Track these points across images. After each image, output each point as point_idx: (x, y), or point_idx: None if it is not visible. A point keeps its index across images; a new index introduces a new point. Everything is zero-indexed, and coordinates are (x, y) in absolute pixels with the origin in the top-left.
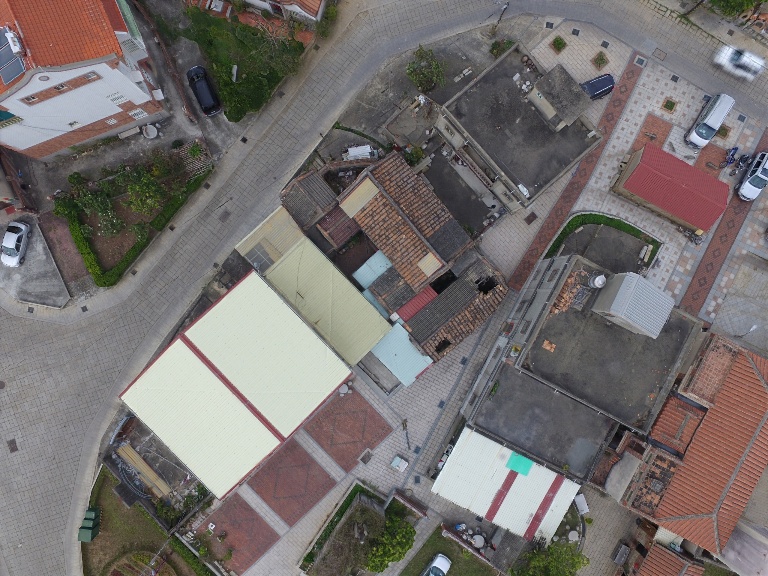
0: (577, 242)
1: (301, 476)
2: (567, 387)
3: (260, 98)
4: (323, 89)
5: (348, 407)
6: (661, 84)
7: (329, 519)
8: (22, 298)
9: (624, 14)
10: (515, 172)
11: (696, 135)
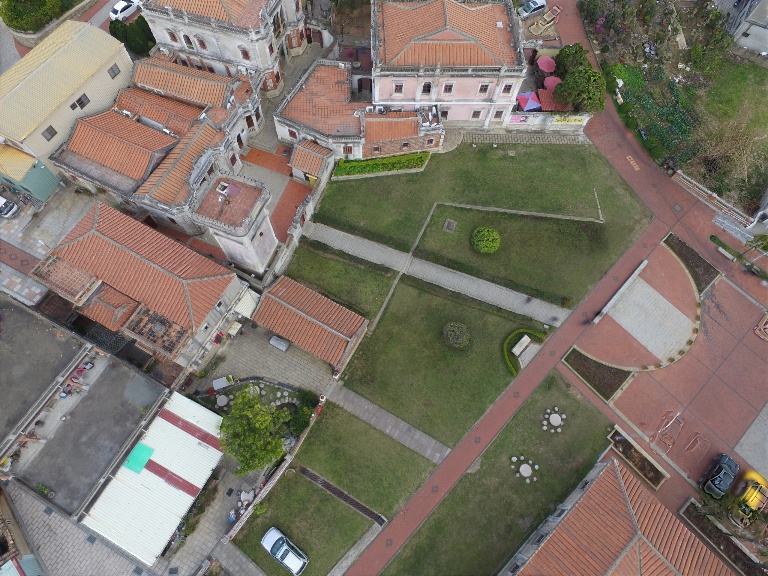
0: None
1: None
2: None
3: None
4: None
5: None
6: None
7: None
8: None
9: None
10: None
11: None
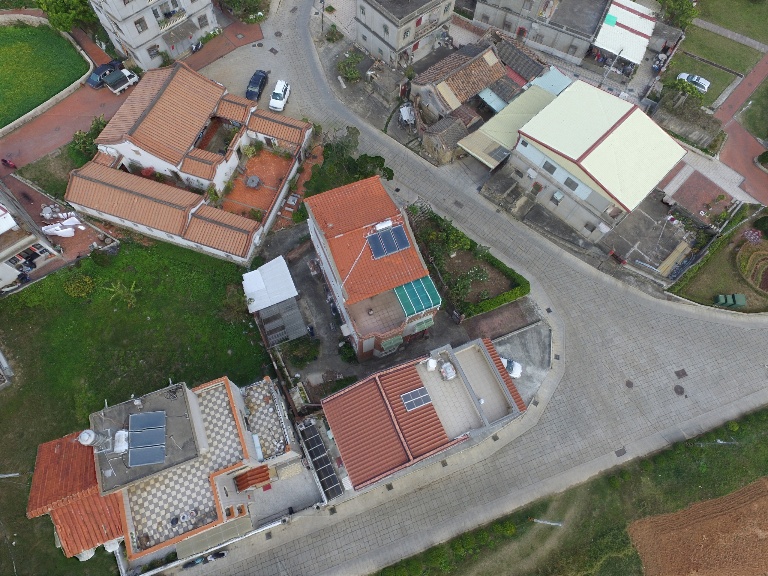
0: (460, 2)
1: None
2: None
3: None
4: None
5: None
6: None
7: None
8: (547, 365)
9: None
10: None
11: None
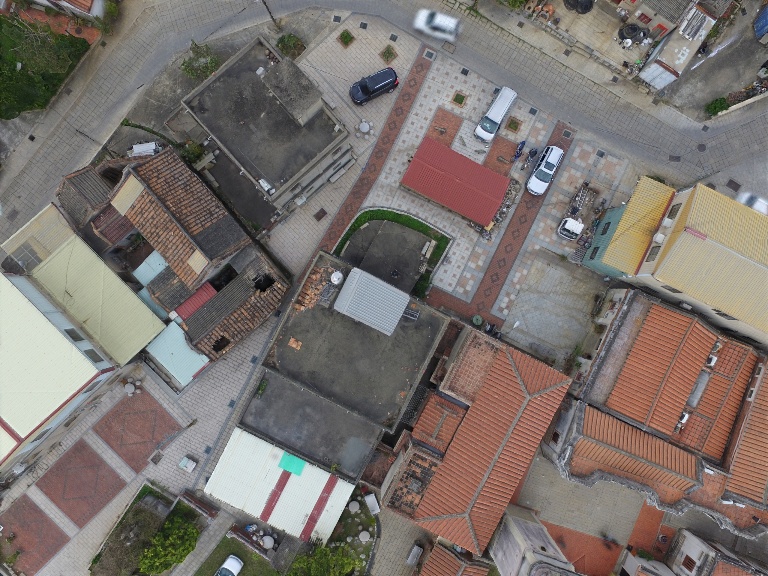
0: (362, 238)
1: (91, 477)
2: (314, 385)
3: (31, 95)
4: (111, 86)
5: (138, 407)
6: (451, 77)
7: (118, 520)
8: None
9: (412, 7)
10: (260, 167)
11: (481, 129)
